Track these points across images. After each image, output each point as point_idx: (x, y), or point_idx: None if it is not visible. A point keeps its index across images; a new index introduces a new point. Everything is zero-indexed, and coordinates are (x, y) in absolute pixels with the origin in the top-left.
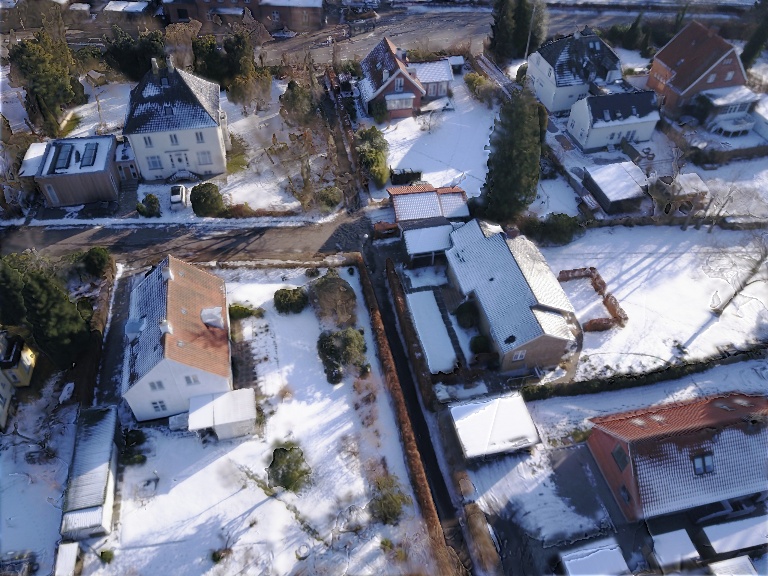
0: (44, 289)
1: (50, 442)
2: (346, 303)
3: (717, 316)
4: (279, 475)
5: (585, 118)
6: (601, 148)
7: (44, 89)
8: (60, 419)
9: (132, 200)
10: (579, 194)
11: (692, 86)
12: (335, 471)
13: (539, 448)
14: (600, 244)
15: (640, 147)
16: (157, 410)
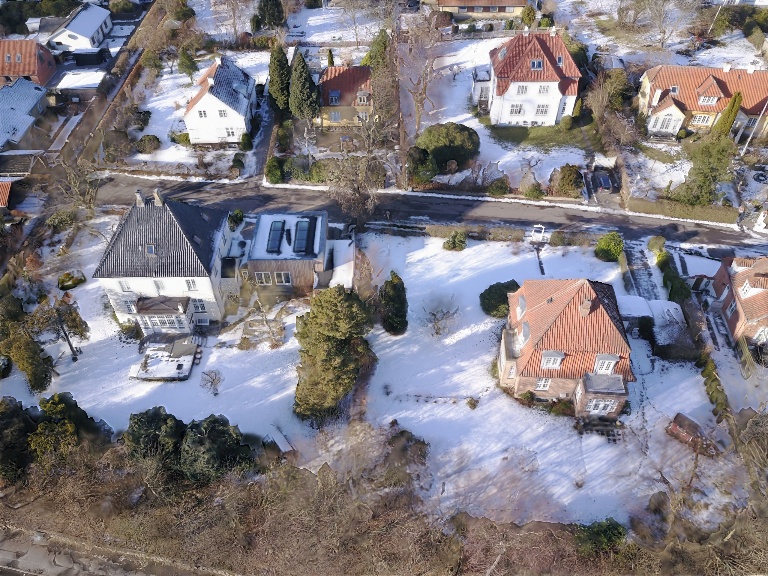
0: None
1: None
2: None
3: None
4: None
5: None
6: None
7: None
8: None
9: (249, 239)
10: None
11: None
12: (169, 88)
13: None
14: None
15: None
16: None
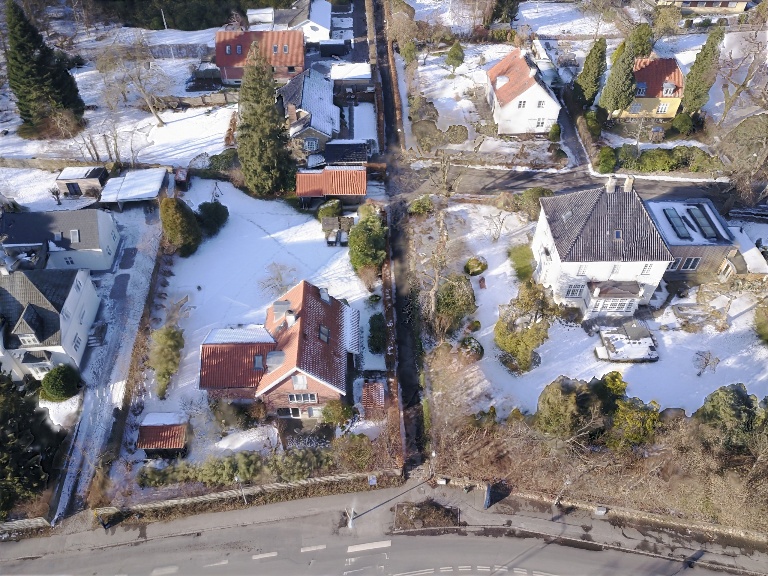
0: None
1: None
2: None
3: (165, 123)
4: None
5: None
6: None
7: None
8: None
9: None
10: None
11: None
12: (433, 79)
13: None
14: None
15: None
16: None
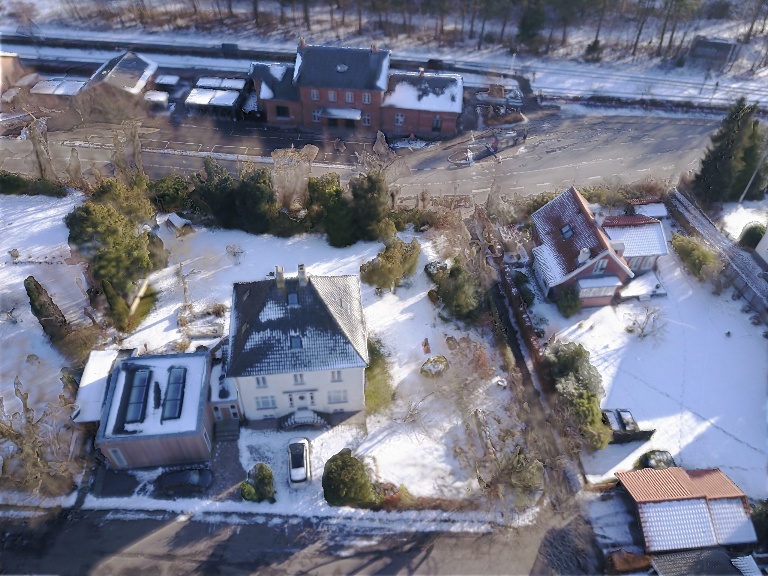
0: None
1: None
2: None
3: None
4: None
5: None
6: None
7: (113, 269)
8: None
9: (231, 461)
10: None
11: None
12: None
13: None
14: None
15: None
16: None
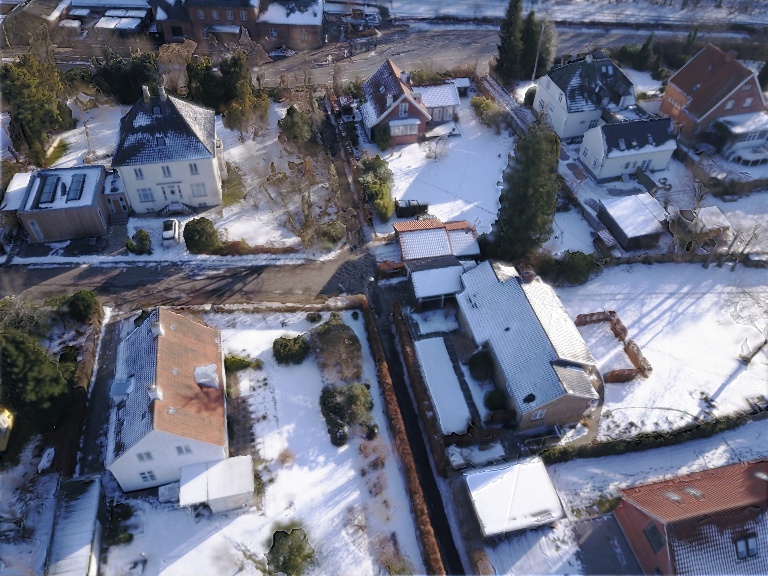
0: (20, 352)
1: (26, 522)
2: (351, 353)
3: (745, 364)
4: (280, 562)
5: (599, 147)
6: (615, 178)
7: (29, 115)
8: (39, 490)
9: (121, 235)
10: (594, 228)
11: (709, 113)
12: (341, 549)
13: (564, 523)
14: (618, 284)
15: (656, 177)
16: (145, 480)
